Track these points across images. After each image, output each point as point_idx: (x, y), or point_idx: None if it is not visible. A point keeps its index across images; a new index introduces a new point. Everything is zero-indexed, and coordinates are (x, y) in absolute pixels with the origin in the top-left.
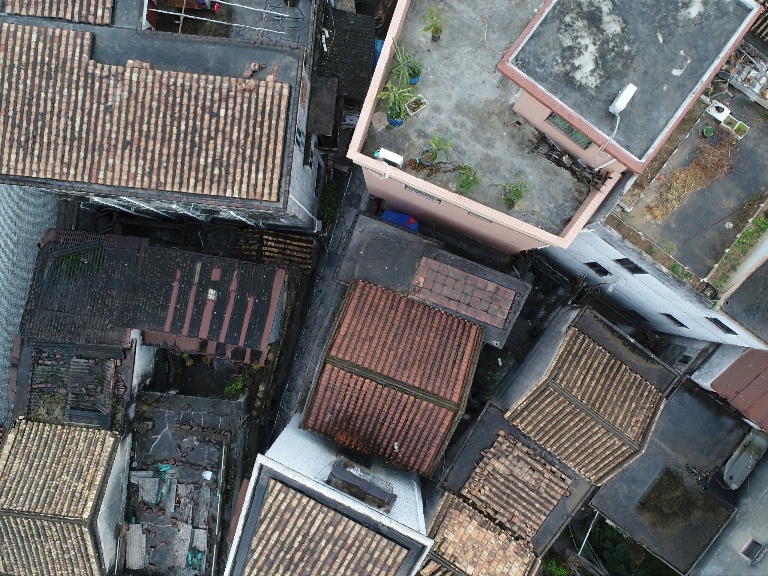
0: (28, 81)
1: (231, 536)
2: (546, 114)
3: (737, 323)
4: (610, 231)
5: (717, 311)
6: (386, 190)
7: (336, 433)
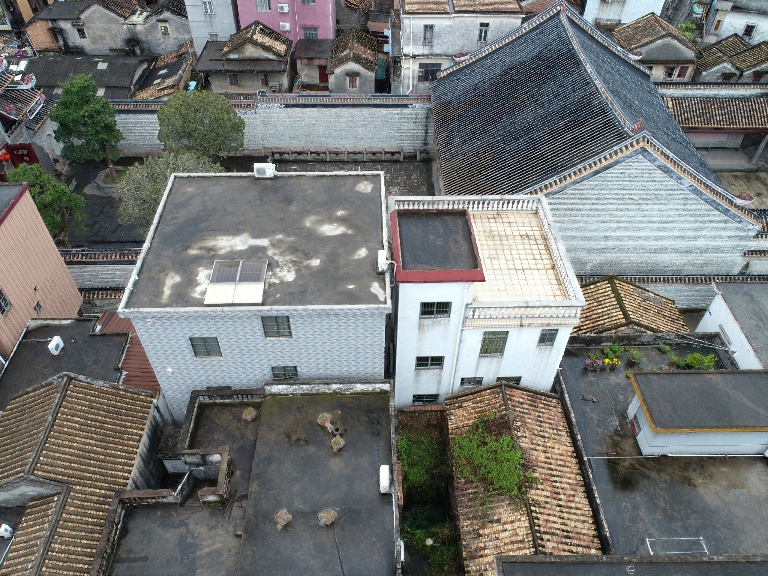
0: (478, 5)
1: None
2: None
3: None
4: None
5: None
6: None
7: (578, 3)
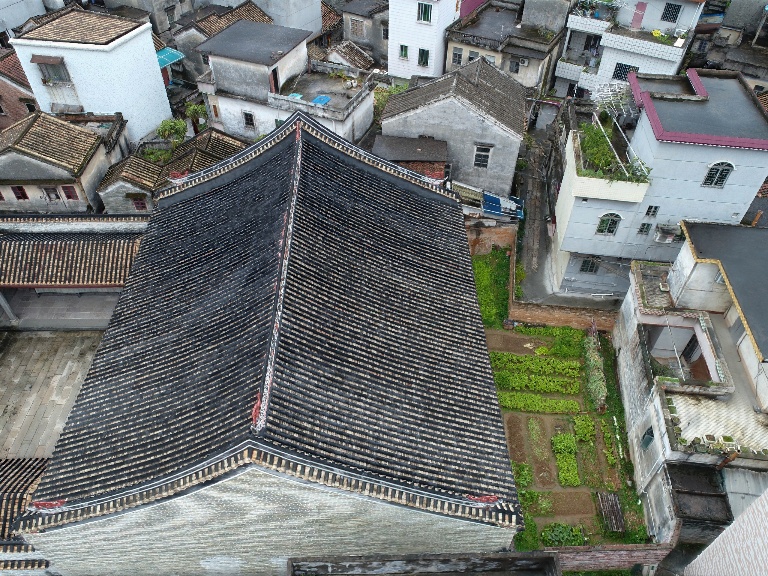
0: None
1: (58, 63)
2: None
3: None
4: None
5: None
6: None
7: None
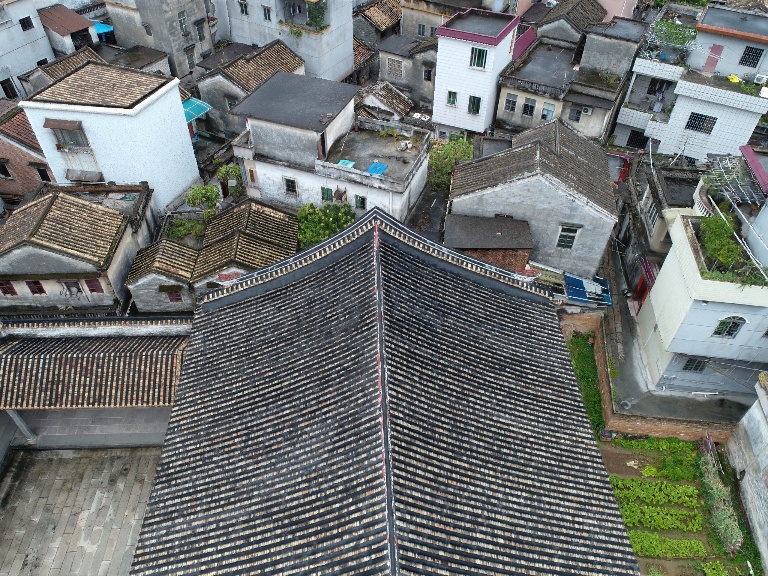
0: None
1: (76, 128)
2: None
3: None
4: None
5: (3, 4)
6: None
7: None
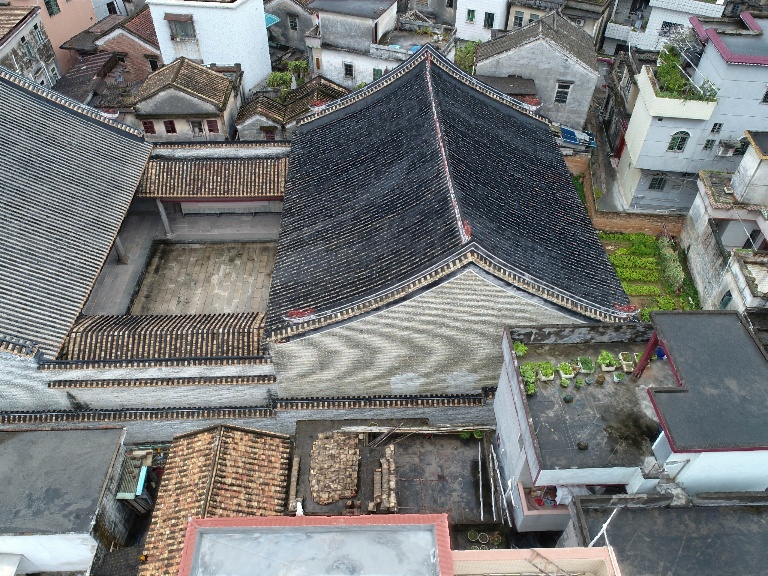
0: None
1: (189, 20)
2: None
3: None
4: None
5: None
6: (53, 45)
7: None
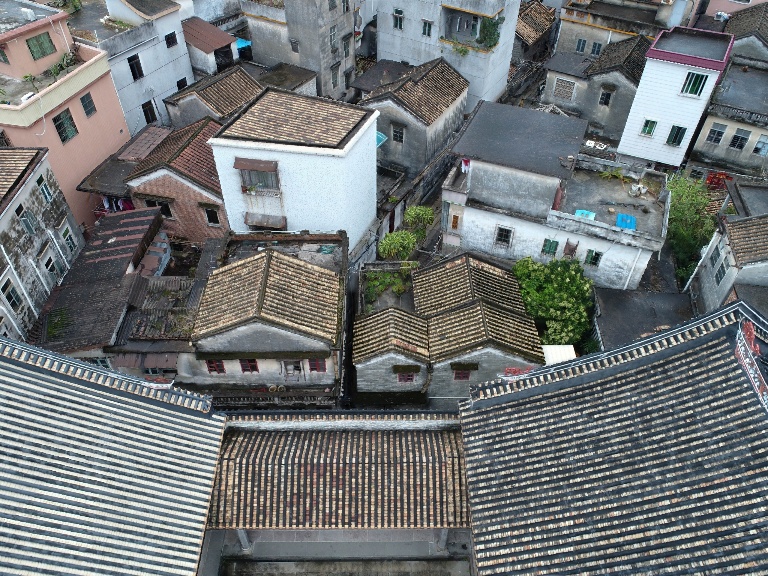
0: None
1: (272, 169)
2: (30, 53)
3: (159, 13)
4: (103, 41)
5: (153, 19)
6: (67, 182)
7: None
